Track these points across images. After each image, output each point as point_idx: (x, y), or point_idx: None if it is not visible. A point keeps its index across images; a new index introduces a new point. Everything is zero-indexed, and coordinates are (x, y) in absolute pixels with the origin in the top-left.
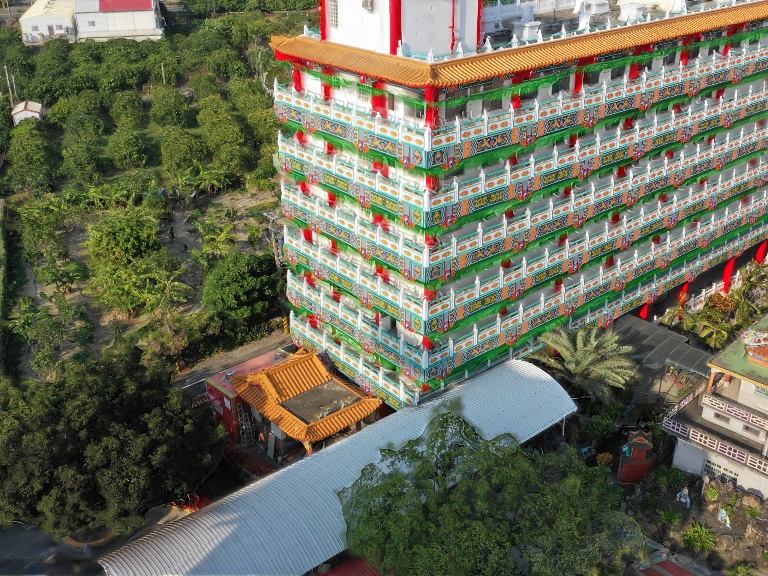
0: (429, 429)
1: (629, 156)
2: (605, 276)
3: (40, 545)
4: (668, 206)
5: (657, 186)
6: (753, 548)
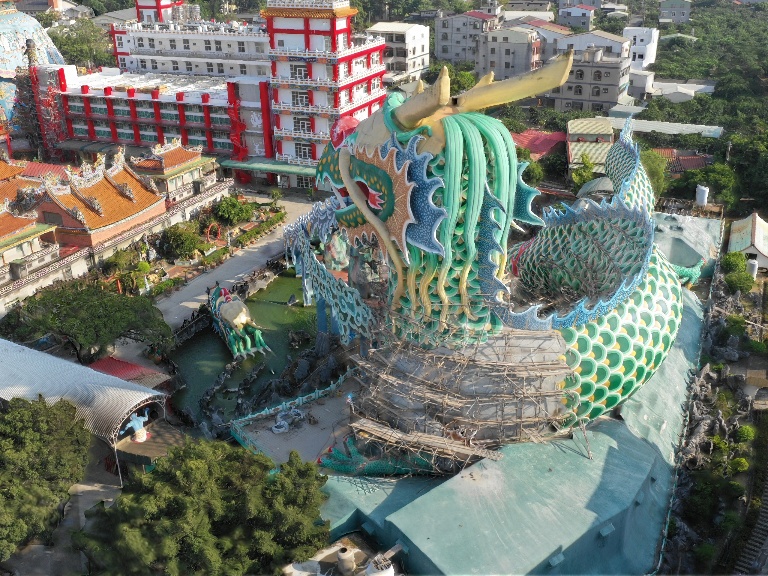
0: (45, 304)
1: None
2: None
3: (36, 563)
4: None
5: None
6: None
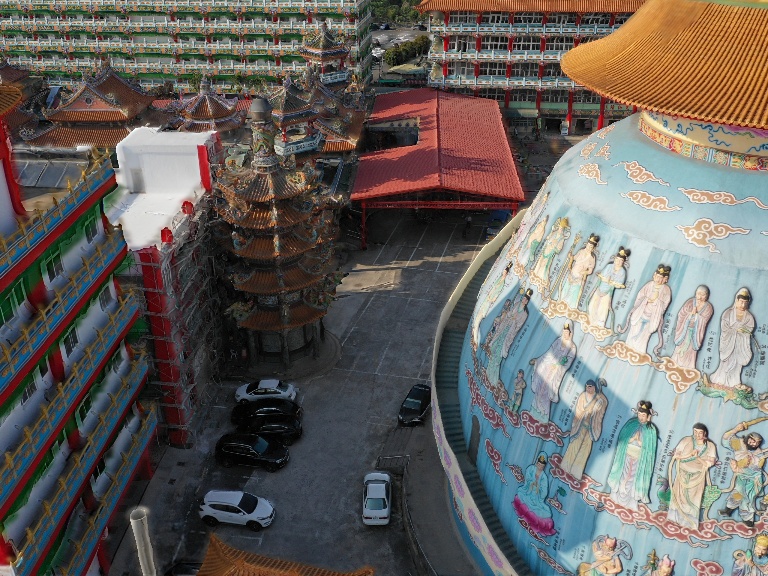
0: None
1: (52, 10)
2: (58, 63)
3: None
4: (93, 42)
5: (78, 29)
6: None
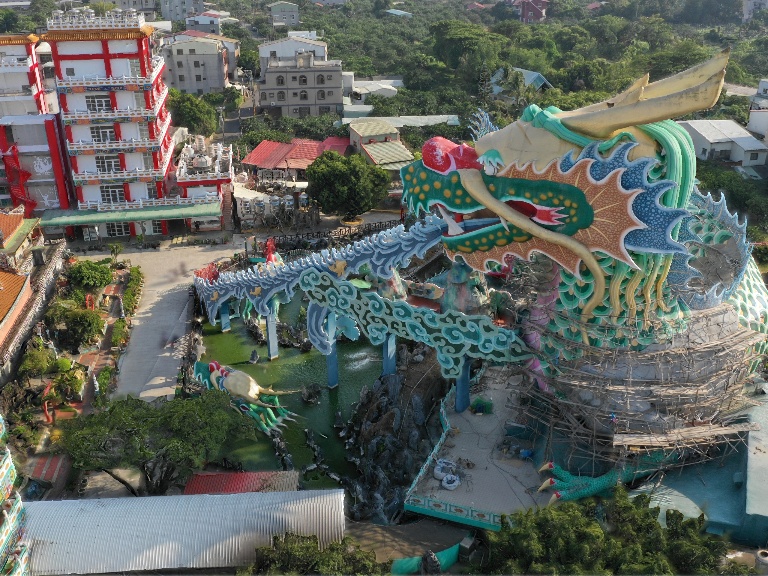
0: (122, 433)
1: None
2: None
3: None
4: None
5: None
6: (8, 440)
